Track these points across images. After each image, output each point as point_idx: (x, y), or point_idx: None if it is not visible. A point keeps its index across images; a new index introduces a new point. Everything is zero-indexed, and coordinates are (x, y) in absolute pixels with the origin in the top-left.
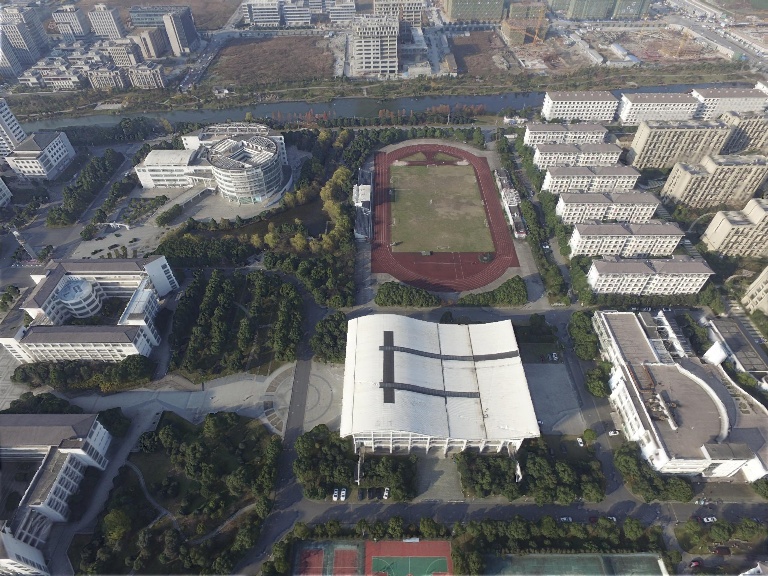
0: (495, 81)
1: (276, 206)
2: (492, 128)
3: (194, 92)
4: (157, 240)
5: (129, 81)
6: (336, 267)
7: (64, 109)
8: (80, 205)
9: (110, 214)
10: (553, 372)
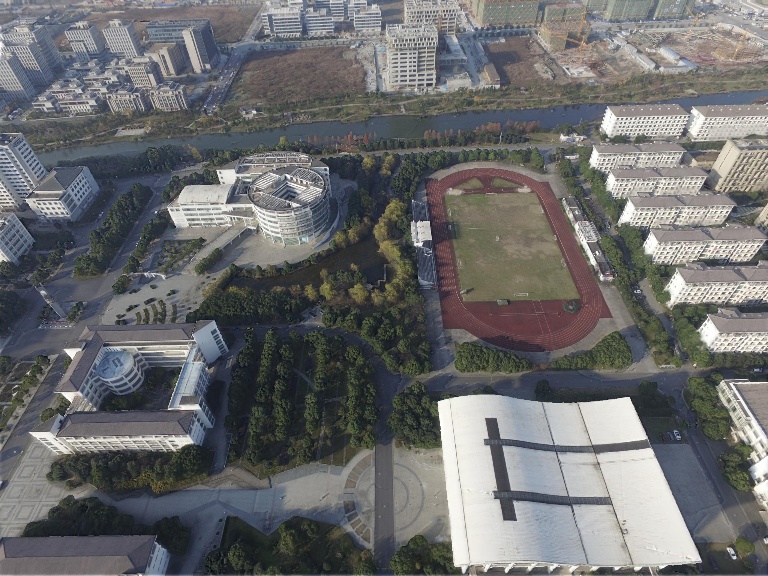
0: (542, 93)
1: (325, 247)
2: (549, 147)
3: (220, 113)
4: (198, 292)
5: (150, 103)
6: (404, 323)
7: (83, 136)
8: (109, 251)
9: (143, 261)
10: (678, 456)
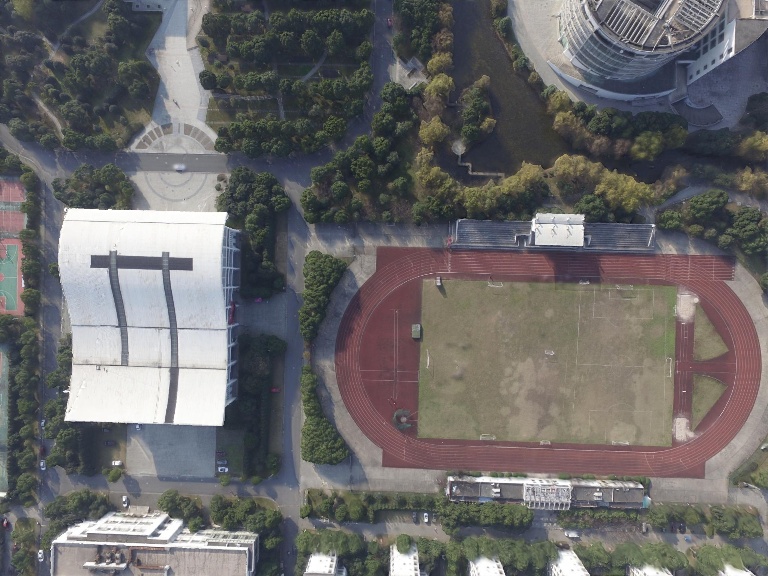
0: None
1: (551, 81)
2: None
3: None
4: None
5: None
6: None
7: None
8: None
9: None
10: (203, 460)
